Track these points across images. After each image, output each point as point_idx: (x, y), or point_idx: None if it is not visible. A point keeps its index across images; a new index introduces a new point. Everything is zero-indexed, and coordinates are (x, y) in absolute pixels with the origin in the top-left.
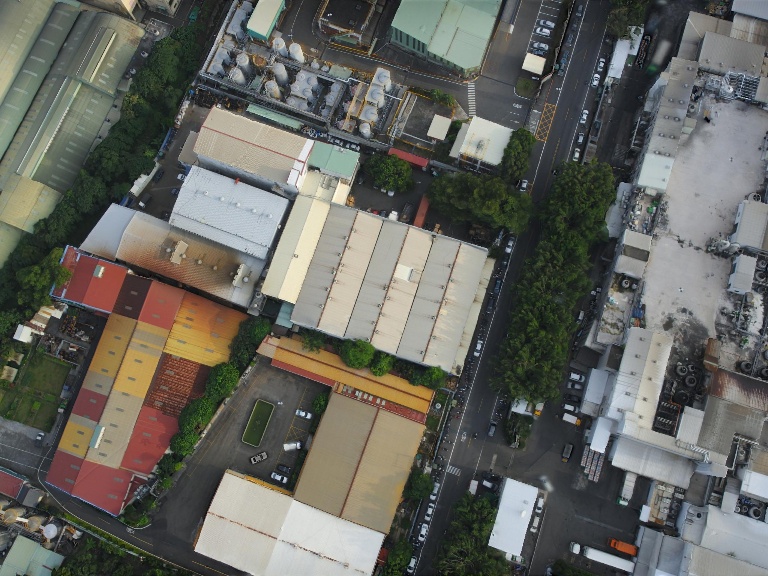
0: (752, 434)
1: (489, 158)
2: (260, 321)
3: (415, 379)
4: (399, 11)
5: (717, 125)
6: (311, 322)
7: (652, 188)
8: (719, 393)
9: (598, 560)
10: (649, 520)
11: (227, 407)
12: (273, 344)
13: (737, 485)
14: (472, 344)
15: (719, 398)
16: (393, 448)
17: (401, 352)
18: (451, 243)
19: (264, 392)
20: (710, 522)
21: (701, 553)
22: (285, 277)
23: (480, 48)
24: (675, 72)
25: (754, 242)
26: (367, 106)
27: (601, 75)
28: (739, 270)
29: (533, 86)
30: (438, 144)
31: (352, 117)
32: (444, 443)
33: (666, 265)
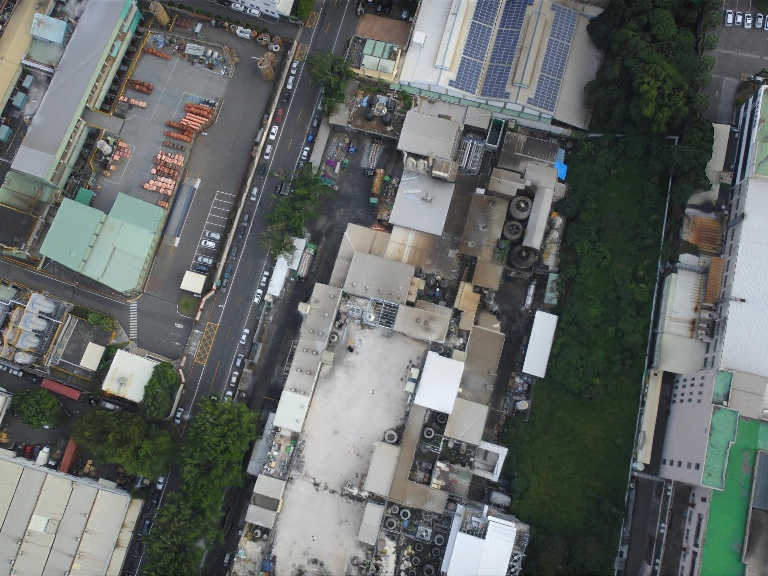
0: None
1: (131, 395)
2: None
3: None
4: (48, 236)
5: (361, 354)
6: None
7: (286, 429)
8: None
9: None
10: None
11: None
12: None
13: None
14: None
15: None
16: None
17: None
18: (89, 489)
19: None
20: None
21: None
22: None
23: (137, 268)
24: (317, 300)
25: (381, 489)
26: (25, 332)
27: (265, 289)
28: (364, 521)
29: (196, 303)
30: (96, 371)
31: (10, 344)
32: None
33: (300, 511)
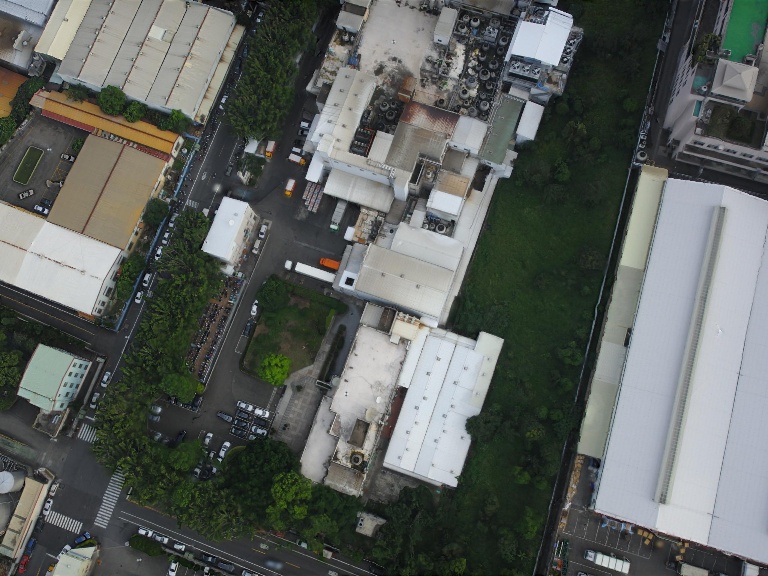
0: (433, 153)
1: None
2: (35, 79)
3: (160, 122)
4: None
5: None
6: (73, 73)
7: None
8: (408, 119)
9: (304, 272)
10: (353, 240)
11: (4, 153)
12: (43, 96)
13: (425, 204)
14: (219, 99)
15: (408, 124)
16: (135, 179)
17: (149, 99)
18: (201, 8)
19: (36, 140)
20: (398, 234)
21: (378, 251)
22: (55, 37)
23: None
24: None
25: None
26: None
27: None
28: (440, 20)
29: None
30: None
31: None
32: (186, 181)
33: (383, 21)
